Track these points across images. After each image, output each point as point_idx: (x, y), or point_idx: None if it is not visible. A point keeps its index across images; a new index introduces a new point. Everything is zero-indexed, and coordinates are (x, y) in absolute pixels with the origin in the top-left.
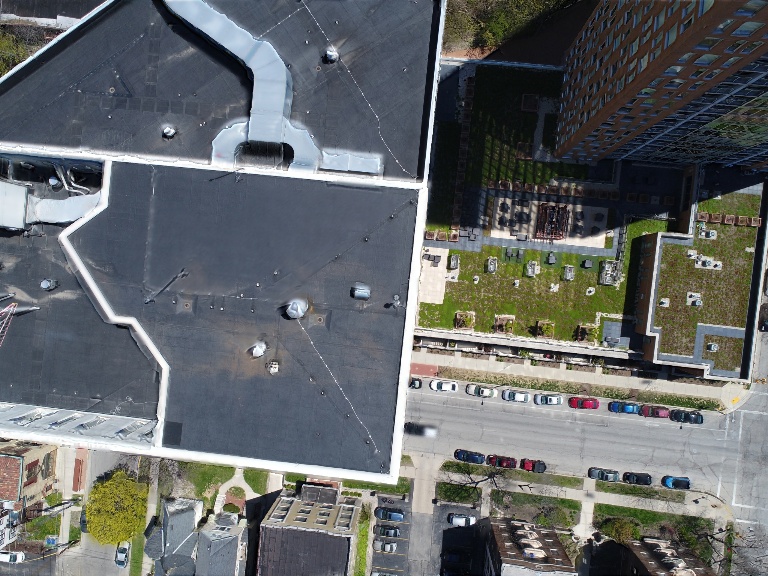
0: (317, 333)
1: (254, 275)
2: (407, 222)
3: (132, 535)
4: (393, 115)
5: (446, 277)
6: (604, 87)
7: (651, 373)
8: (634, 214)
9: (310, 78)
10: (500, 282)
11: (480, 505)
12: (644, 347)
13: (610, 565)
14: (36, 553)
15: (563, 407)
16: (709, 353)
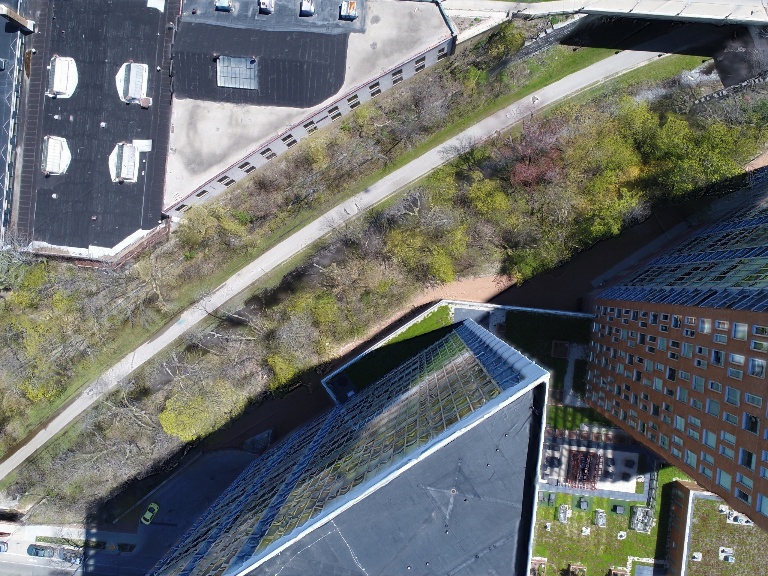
0: None
1: None
2: None
3: None
4: None
5: None
6: (644, 415)
7: None
8: (665, 462)
9: None
10: None
11: None
12: None
13: None
14: None
15: None
16: None
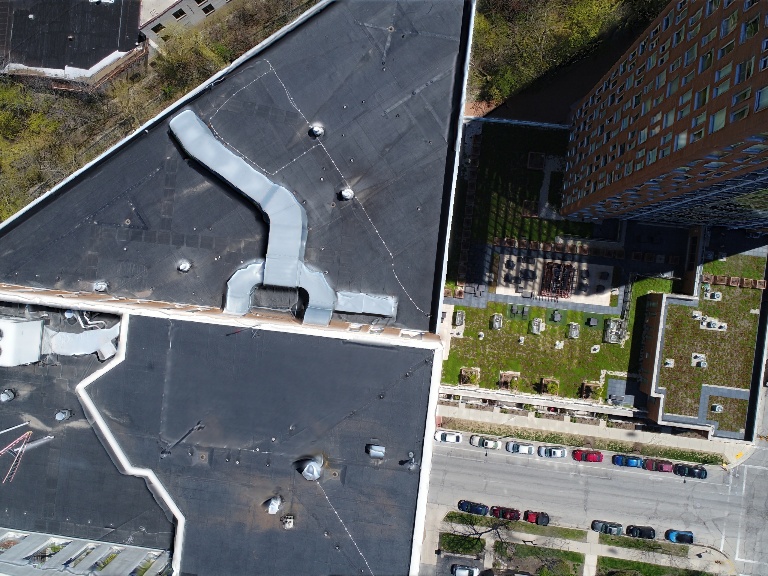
0: (332, 488)
1: (270, 429)
2: (422, 381)
3: None
4: (407, 253)
5: (451, 333)
6: (611, 164)
7: (655, 427)
8: (639, 273)
9: (325, 214)
10: (505, 339)
11: (483, 556)
12: (648, 406)
13: None
14: None
15: (567, 459)
16: (713, 414)
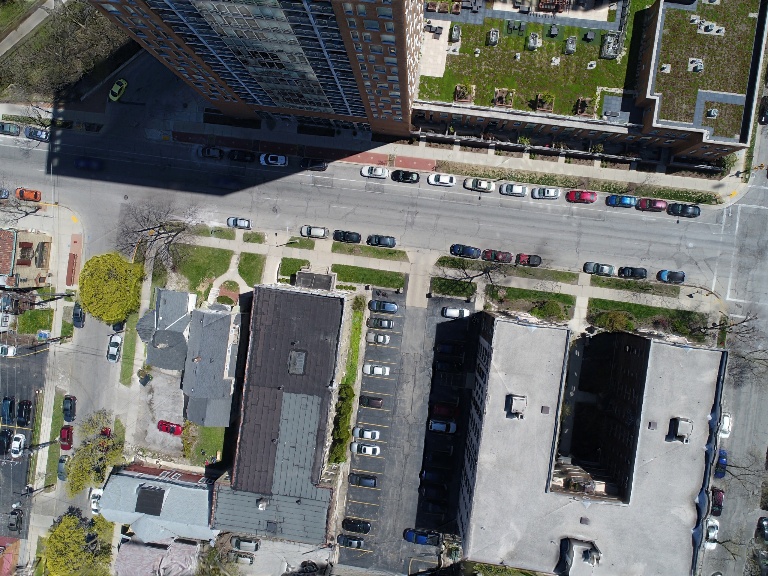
0: None
1: None
2: None
3: (124, 330)
4: None
5: (447, 50)
6: None
7: (650, 166)
8: None
9: None
10: (501, 55)
11: (474, 299)
12: (644, 120)
13: (603, 357)
14: (28, 348)
15: (560, 202)
16: (709, 120)
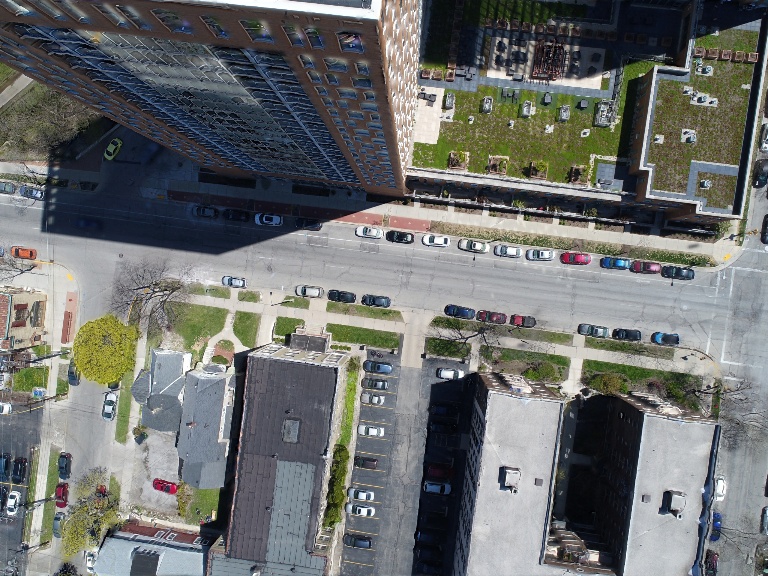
0: None
1: None
2: None
3: (120, 388)
4: None
5: (441, 117)
6: None
7: (644, 228)
8: (631, 54)
9: None
10: (495, 122)
11: (469, 360)
12: (637, 188)
13: (597, 419)
14: (23, 406)
15: (555, 263)
16: (702, 190)
